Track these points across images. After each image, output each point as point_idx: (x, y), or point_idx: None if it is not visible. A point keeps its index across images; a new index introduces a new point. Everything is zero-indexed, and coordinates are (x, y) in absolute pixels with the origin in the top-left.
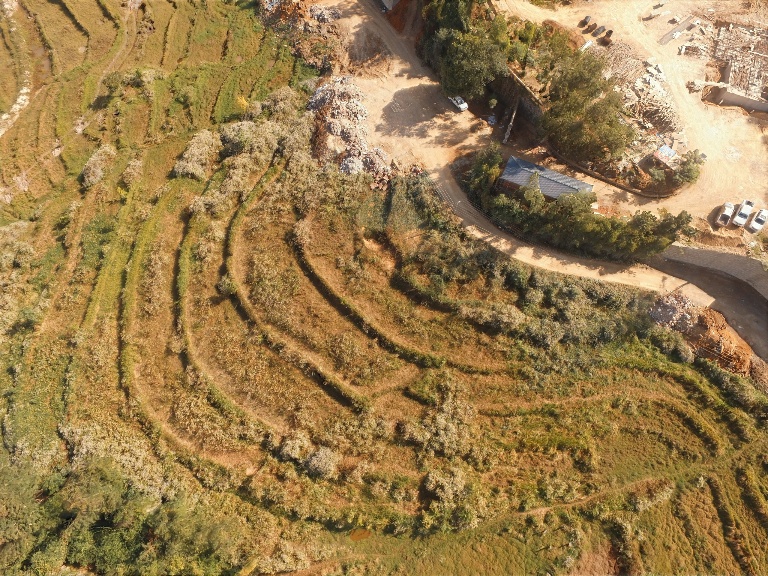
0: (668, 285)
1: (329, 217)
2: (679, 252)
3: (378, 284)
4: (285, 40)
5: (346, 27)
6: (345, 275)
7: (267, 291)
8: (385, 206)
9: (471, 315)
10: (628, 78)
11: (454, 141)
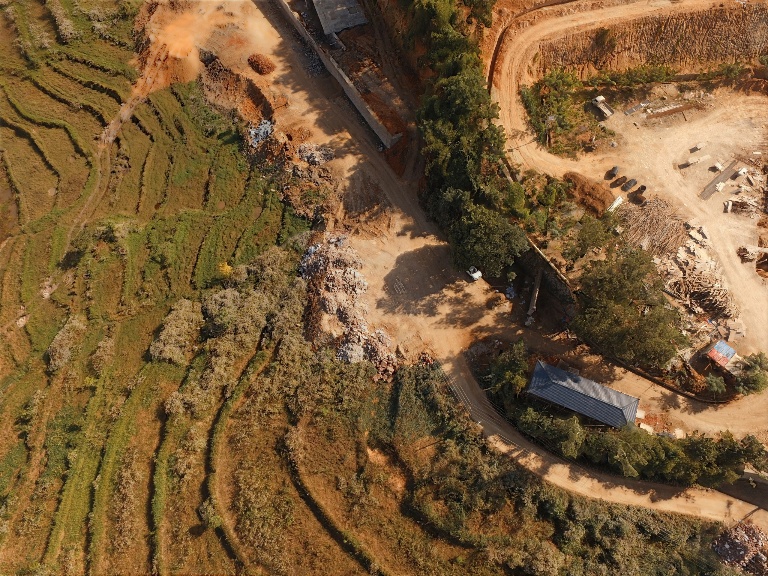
0: (735, 512)
1: (326, 421)
2: (747, 474)
3: (386, 510)
4: (272, 183)
5: (339, 170)
6: (347, 499)
7: (256, 526)
8: (391, 403)
9: (499, 560)
10: (668, 247)
11: (468, 320)
